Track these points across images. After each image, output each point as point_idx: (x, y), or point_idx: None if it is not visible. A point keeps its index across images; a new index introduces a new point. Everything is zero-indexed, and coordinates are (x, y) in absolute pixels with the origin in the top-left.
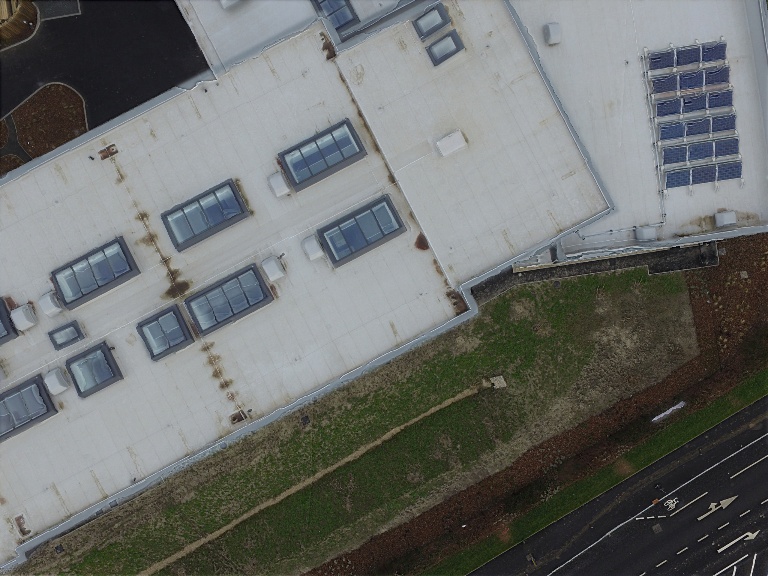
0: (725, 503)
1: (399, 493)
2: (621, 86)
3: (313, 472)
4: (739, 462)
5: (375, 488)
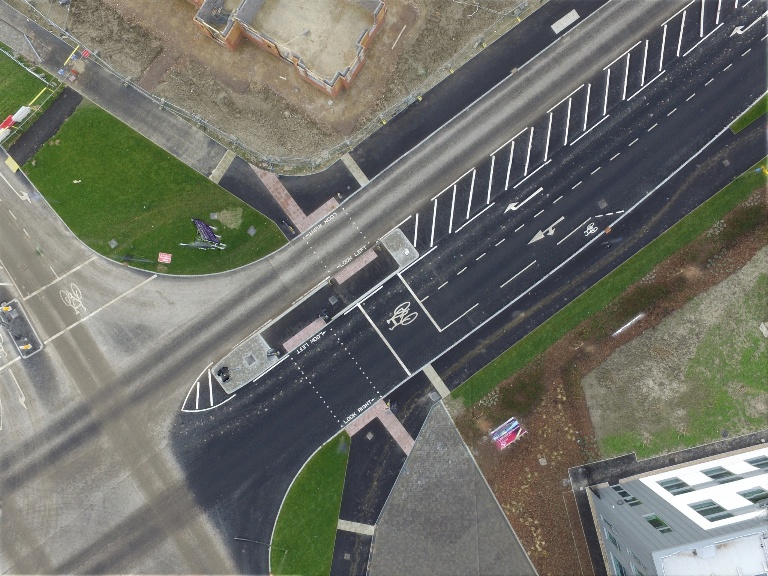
0: (540, 236)
1: None
2: None
3: None
4: (529, 277)
5: None
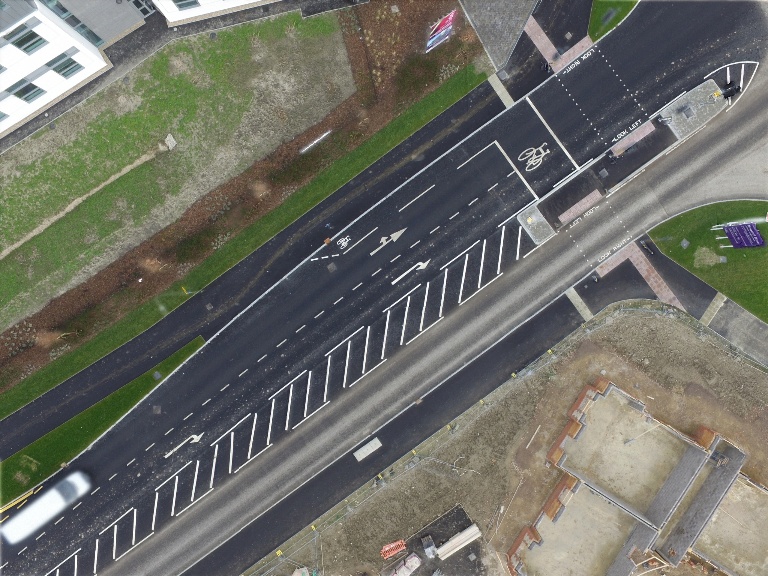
0: (395, 236)
1: (75, 255)
2: None
3: None
4: (406, 195)
5: (55, 255)
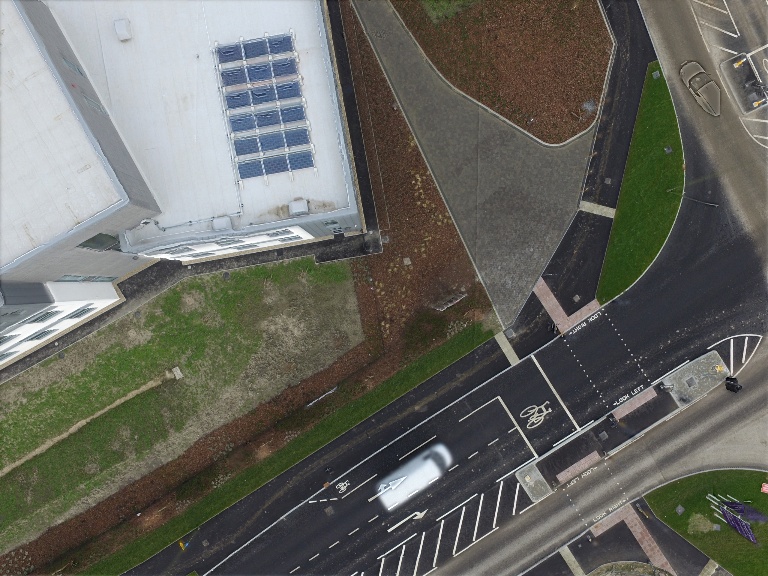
0: (394, 484)
1: (75, 484)
2: (194, 80)
3: (0, 467)
4: (407, 444)
5: (55, 480)
